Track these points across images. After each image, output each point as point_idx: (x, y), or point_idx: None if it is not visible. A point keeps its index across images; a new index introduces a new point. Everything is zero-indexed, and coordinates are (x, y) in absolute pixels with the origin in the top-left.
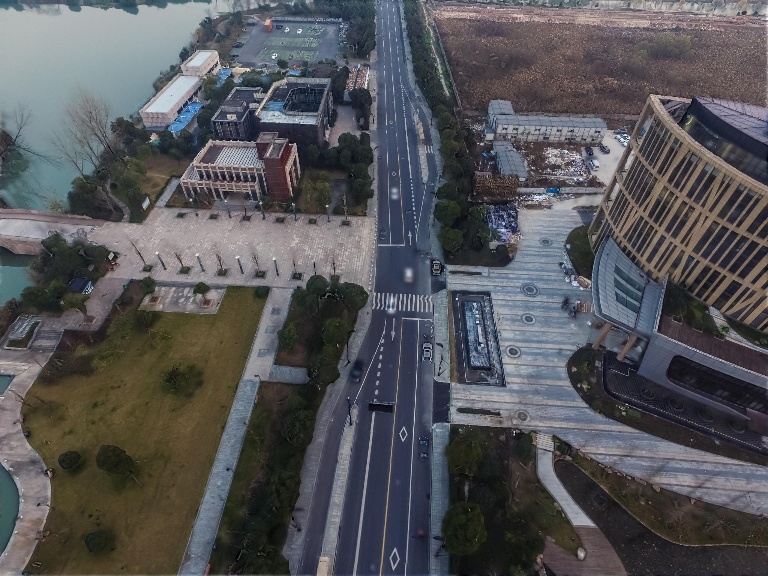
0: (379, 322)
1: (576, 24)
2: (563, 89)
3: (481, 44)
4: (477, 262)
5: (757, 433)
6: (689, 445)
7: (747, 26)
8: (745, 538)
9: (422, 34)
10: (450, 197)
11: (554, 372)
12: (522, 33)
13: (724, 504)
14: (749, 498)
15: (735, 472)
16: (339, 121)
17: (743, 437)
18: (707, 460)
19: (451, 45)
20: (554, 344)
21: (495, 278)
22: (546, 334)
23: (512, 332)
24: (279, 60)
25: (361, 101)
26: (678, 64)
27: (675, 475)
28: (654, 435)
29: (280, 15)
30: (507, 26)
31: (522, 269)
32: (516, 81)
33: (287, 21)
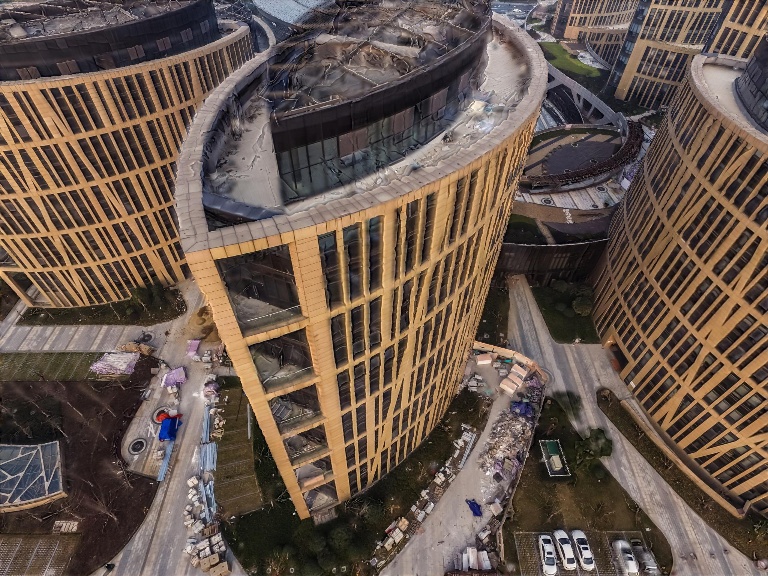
0: (526, 6)
1: None
2: None
3: None
4: None
5: None
6: None
7: None
8: None
9: None
10: None
11: None
12: None
13: None
14: None
15: None
16: None
17: None
18: None
19: None
20: None
21: None
22: None
23: None
24: None
25: None
26: None
27: None
28: None
29: None
30: None
31: None
32: None
33: None
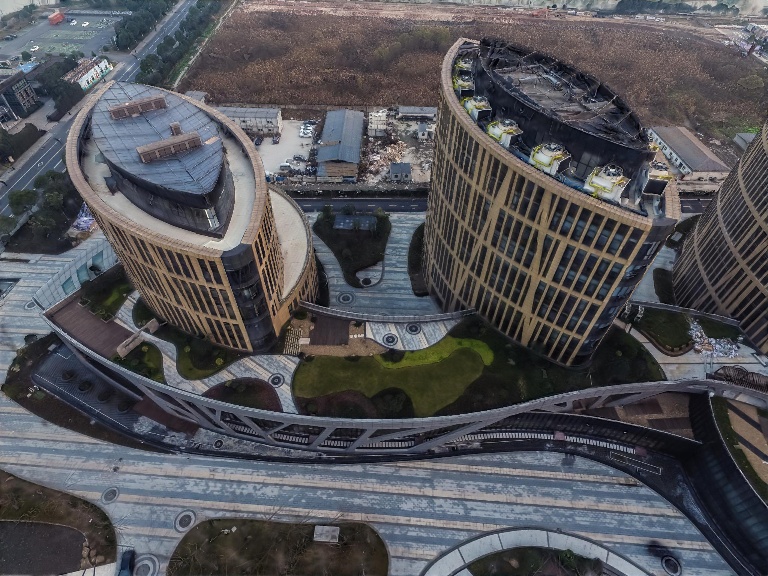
0: None
1: (372, 17)
2: (290, 81)
3: (249, 37)
4: (36, 250)
5: (138, 413)
6: (63, 425)
7: (547, 19)
8: (22, 514)
9: (203, 27)
10: (43, 186)
11: (4, 356)
12: (301, 26)
13: (40, 481)
14: (70, 475)
15: (83, 451)
16: (38, 112)
17: (122, 417)
18: (67, 439)
19: (214, 37)
20: (31, 329)
21: (39, 265)
22: (34, 319)
23: (2, 318)
24: (22, 52)
25: (54, 92)
26: (427, 56)
27: (19, 454)
28: (39, 416)
29: (82, 8)
30: (296, 19)
31: (74, 256)
32: (247, 73)
33: (83, 14)
